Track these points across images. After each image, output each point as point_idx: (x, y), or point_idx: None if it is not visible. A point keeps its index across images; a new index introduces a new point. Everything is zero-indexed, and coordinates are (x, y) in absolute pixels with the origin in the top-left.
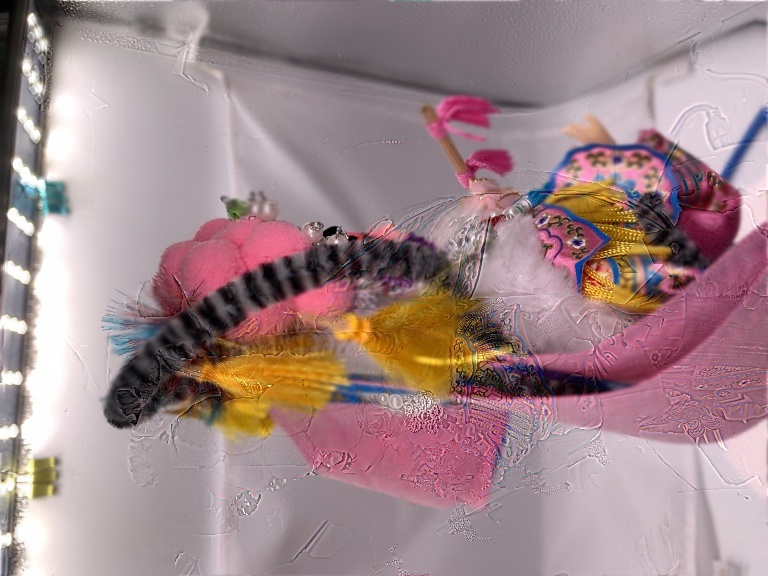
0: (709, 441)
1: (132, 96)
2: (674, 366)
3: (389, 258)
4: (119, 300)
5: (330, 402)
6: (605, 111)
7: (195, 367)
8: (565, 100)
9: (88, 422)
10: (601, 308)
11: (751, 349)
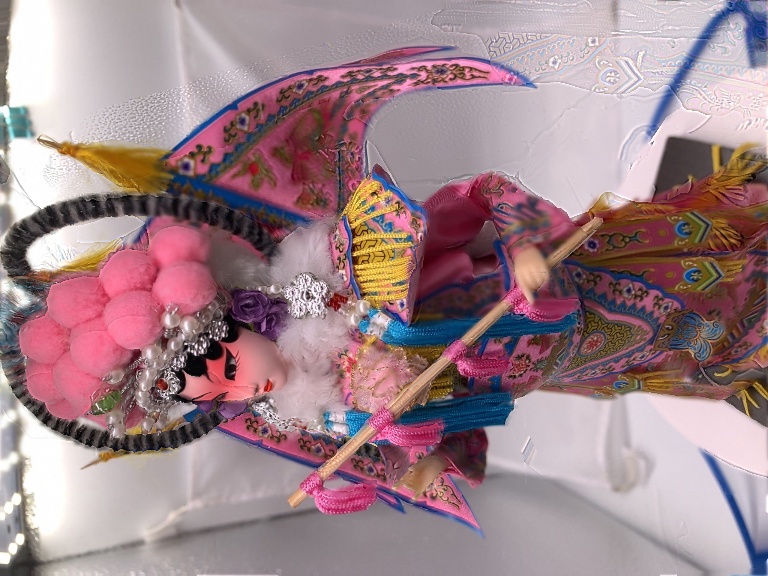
0: (759, 405)
1: (110, 240)
2: (442, 27)
3: (237, 145)
4: None
5: (170, 253)
6: (547, 154)
7: (53, 281)
8: (510, 160)
9: (7, 457)
10: None
11: (528, 5)
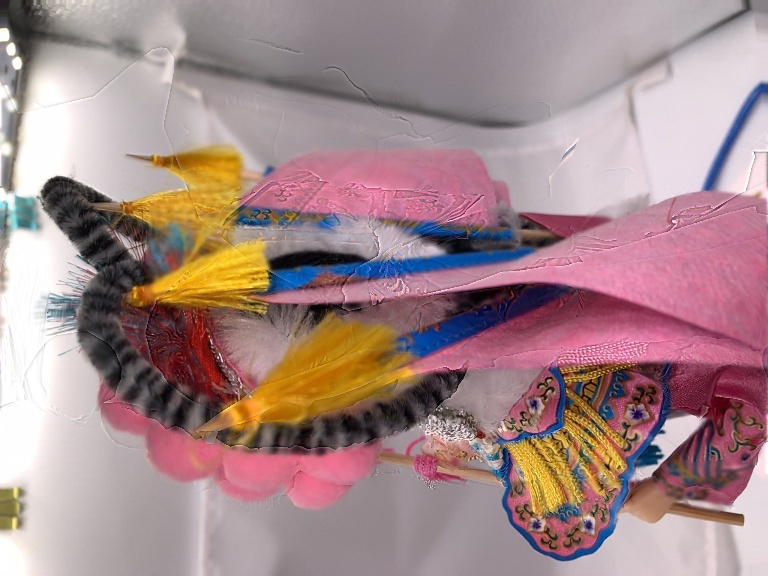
0: None
1: None
2: None
3: None
4: (0, 283)
5: None
6: None
7: None
8: None
9: None
10: (762, 407)
11: None
